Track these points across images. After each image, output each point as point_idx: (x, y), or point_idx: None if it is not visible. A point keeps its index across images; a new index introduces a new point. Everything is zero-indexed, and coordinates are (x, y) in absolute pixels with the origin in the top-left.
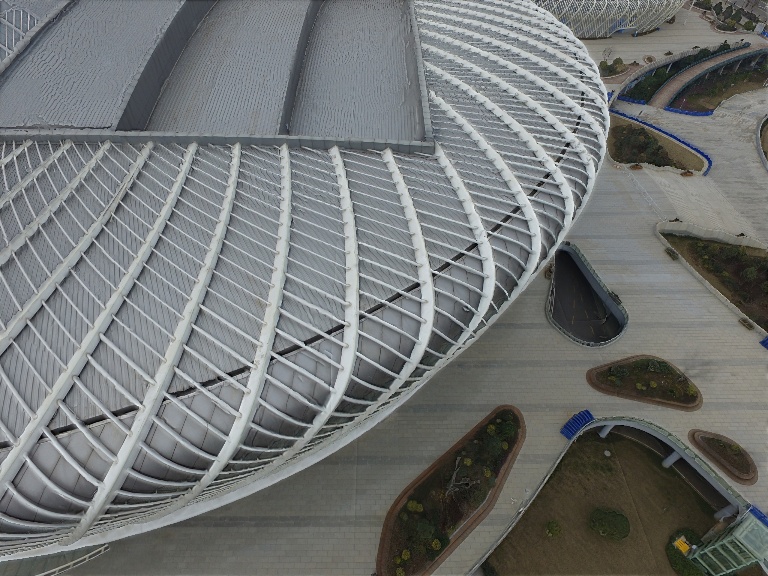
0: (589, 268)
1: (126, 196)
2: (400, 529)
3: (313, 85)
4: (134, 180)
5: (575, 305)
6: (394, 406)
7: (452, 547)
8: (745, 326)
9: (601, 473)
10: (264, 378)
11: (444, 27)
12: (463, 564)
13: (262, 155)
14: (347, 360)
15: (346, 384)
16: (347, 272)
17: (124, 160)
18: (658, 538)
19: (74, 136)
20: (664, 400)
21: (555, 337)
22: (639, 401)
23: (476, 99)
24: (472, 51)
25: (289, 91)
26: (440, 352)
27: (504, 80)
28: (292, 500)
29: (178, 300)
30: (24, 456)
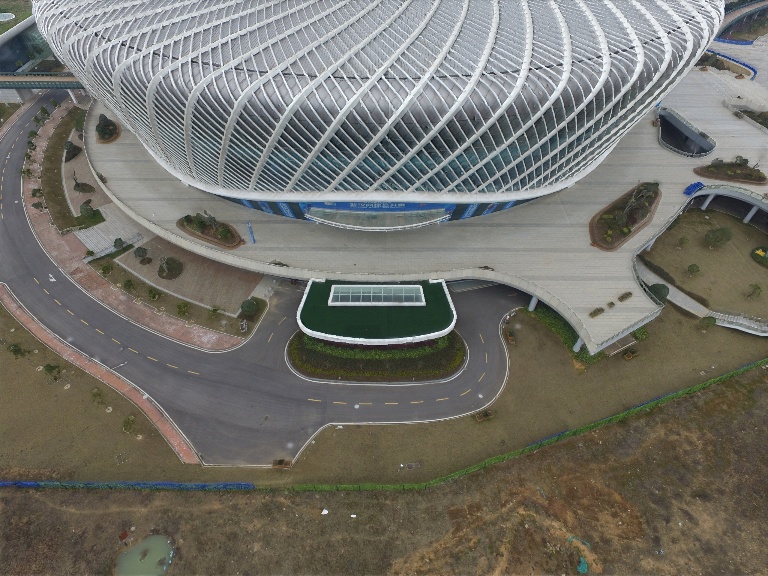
0: (683, 121)
1: None
2: (602, 225)
3: None
4: None
5: None
6: (579, 177)
7: (633, 235)
8: None
9: (705, 225)
10: None
11: None
12: (641, 241)
13: None
14: (641, 58)
15: (642, 67)
16: (627, 29)
17: None
18: (745, 251)
19: None
20: (746, 180)
21: (668, 154)
22: (729, 181)
23: None
24: None
25: None
26: None
27: None
28: (530, 217)
29: (559, 32)
30: None
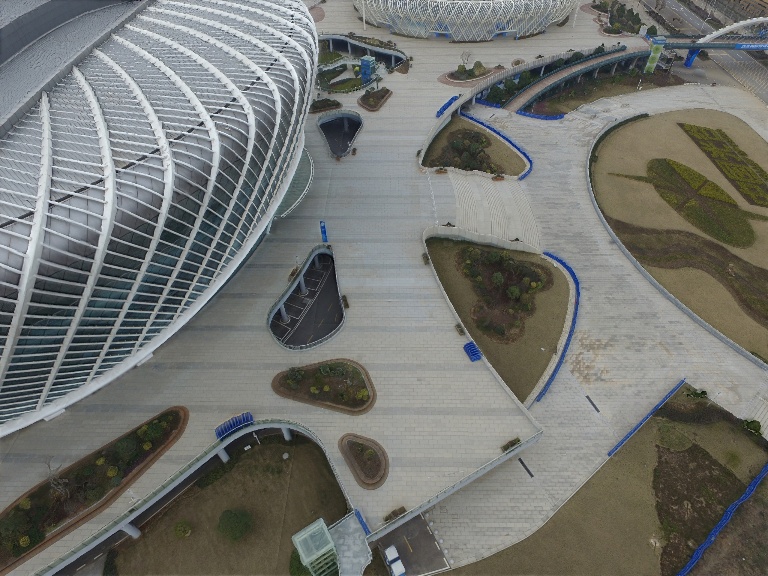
0: (335, 272)
1: None
2: None
3: None
4: None
5: (330, 308)
6: (58, 405)
7: (46, 544)
8: (458, 331)
9: (269, 475)
10: None
11: (144, 33)
12: (48, 561)
13: None
14: None
15: None
16: None
17: None
18: None
19: None
20: (333, 404)
21: (265, 340)
22: (311, 404)
23: (90, 105)
24: (145, 57)
25: None
26: None
27: (142, 86)
28: None
29: None
30: None
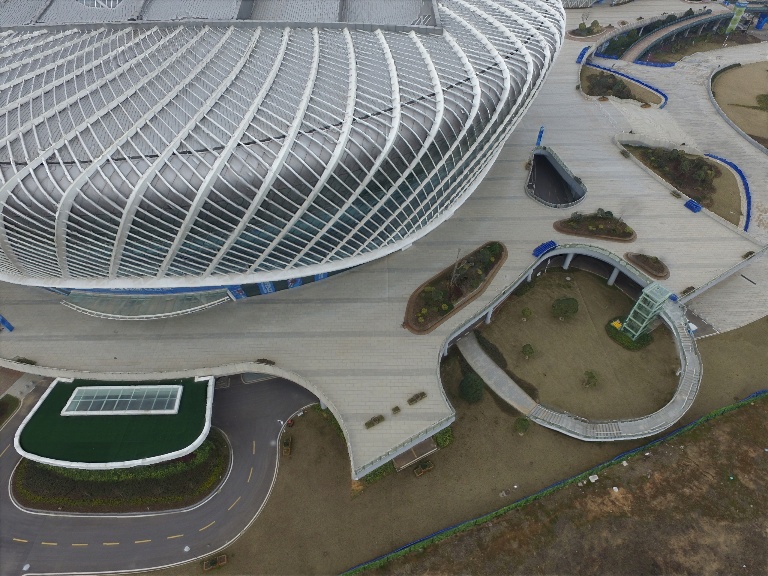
0: (560, 163)
1: (253, 52)
2: (420, 300)
3: (353, 9)
4: (256, 44)
5: (550, 194)
6: (413, 238)
7: (455, 311)
8: (675, 196)
9: (563, 289)
10: (351, 127)
11: None
12: (463, 319)
13: (332, 33)
14: (395, 123)
15: (395, 134)
16: (392, 85)
17: (246, 35)
18: (600, 322)
19: (211, 22)
20: (608, 236)
21: (531, 204)
22: (590, 238)
23: (470, 9)
24: None
25: (340, 8)
26: (447, 141)
27: None
28: (344, 290)
29: (298, 93)
30: (231, 151)
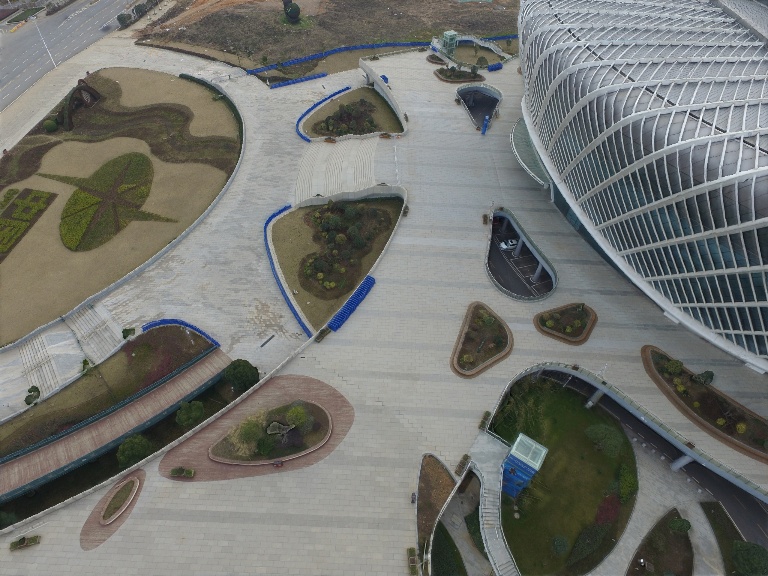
0: None
1: None
2: None
3: None
4: None
5: None
6: None
7: None
8: None
9: None
10: None
11: None
12: None
13: None
14: None
15: None
16: None
17: None
18: None
19: None
20: None
21: None
22: None
23: None
24: None
25: None
26: None
27: None
28: None
29: None
30: None
